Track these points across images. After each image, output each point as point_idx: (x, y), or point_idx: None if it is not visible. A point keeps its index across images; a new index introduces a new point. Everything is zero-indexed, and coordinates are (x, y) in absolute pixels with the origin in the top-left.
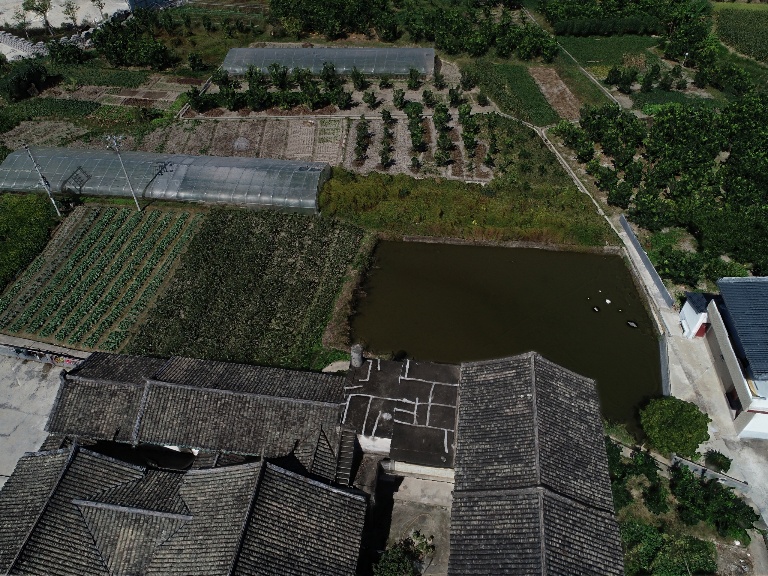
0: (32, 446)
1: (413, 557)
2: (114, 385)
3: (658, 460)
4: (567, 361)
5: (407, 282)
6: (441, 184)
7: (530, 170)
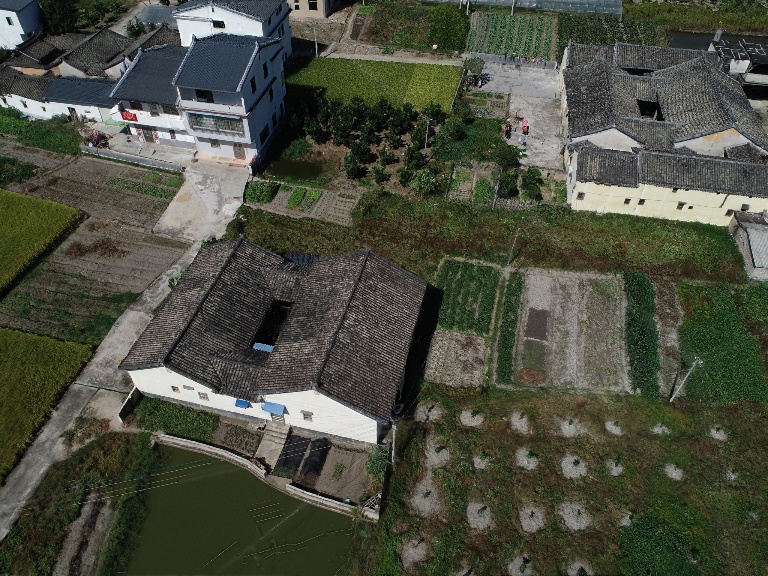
0: (536, 89)
1: None
2: (596, 47)
3: None
4: None
5: (691, 46)
6: (690, 8)
7: (741, 4)
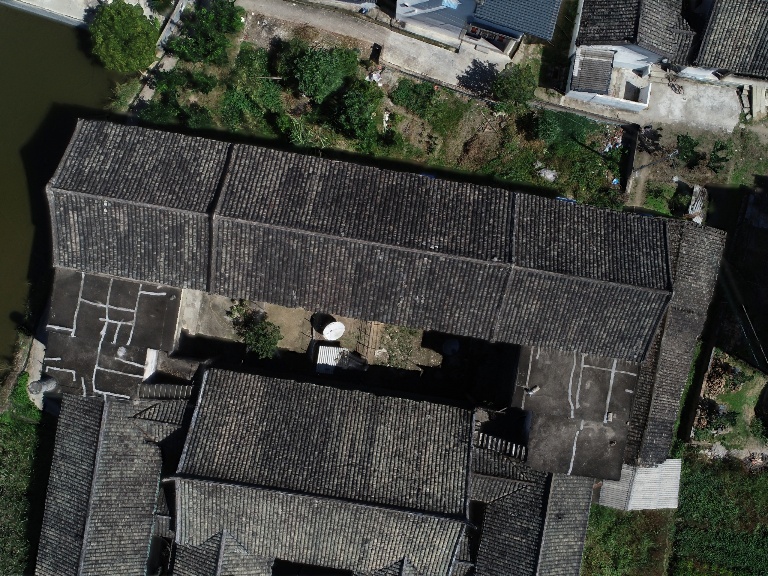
0: None
1: (250, 319)
2: None
3: (157, 62)
4: (27, 122)
5: None
6: None
7: None
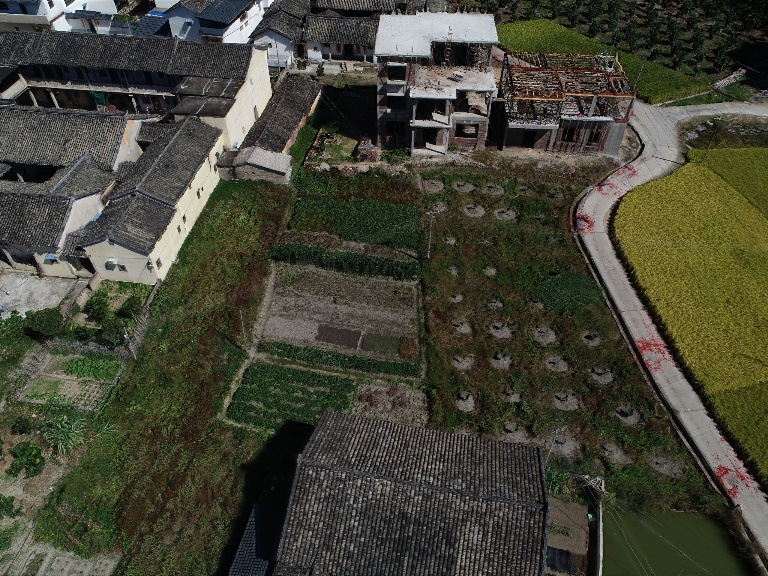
0: None
1: None
2: None
3: None
4: None
5: None
6: None
7: None
